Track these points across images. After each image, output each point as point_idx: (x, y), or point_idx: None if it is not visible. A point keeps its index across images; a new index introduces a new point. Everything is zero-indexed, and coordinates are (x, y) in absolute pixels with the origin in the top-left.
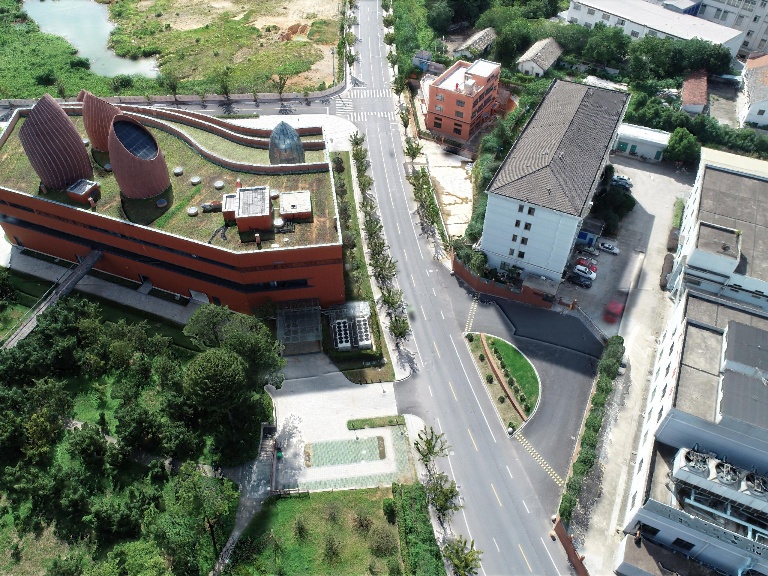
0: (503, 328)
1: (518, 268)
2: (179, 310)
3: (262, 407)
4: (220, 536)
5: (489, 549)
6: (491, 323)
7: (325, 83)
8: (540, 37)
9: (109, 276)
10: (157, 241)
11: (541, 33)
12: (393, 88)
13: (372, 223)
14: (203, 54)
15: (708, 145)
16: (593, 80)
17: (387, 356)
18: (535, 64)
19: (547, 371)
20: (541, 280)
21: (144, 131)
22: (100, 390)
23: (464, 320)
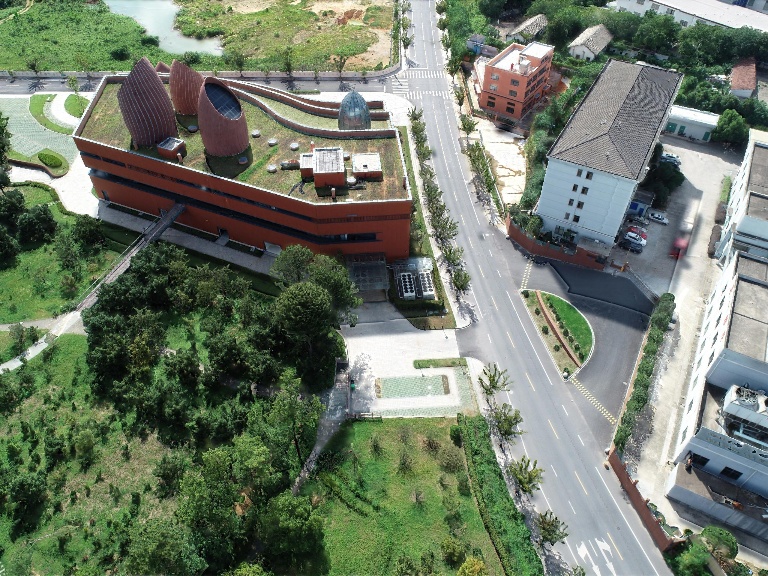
0: (557, 286)
1: (572, 232)
2: (254, 260)
3: (335, 345)
4: (304, 449)
5: (547, 474)
6: (546, 282)
7: (382, 64)
8: (590, 24)
9: (189, 229)
10: (240, 194)
11: (592, 20)
12: (447, 69)
13: (432, 189)
14: (264, 35)
15: (756, 127)
16: None
17: (448, 307)
18: (586, 48)
19: (600, 324)
20: (595, 243)
21: (230, 94)
22: (190, 323)
23: (520, 278)
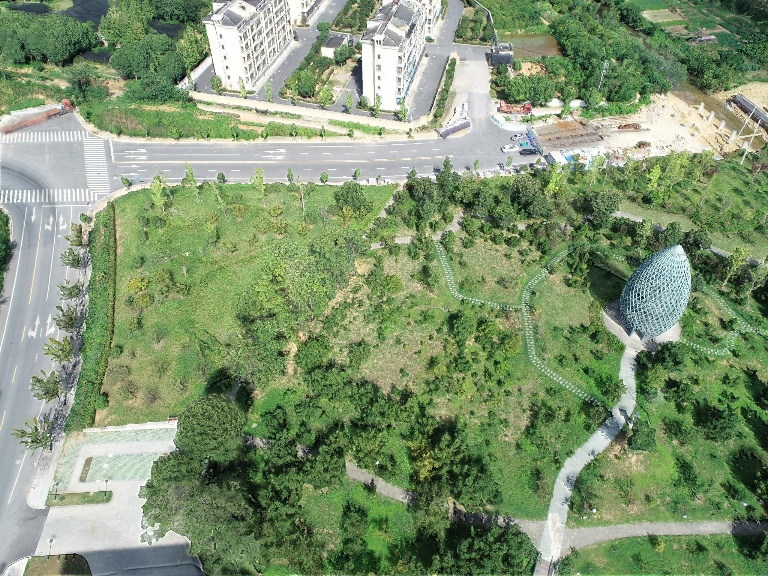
0: None
1: None
2: None
3: None
4: None
5: None
6: None
7: None
8: None
9: None
10: None
11: None
12: None
13: None
14: None
15: None
16: None
17: None
18: None
19: None
20: None
21: None
22: None
23: None
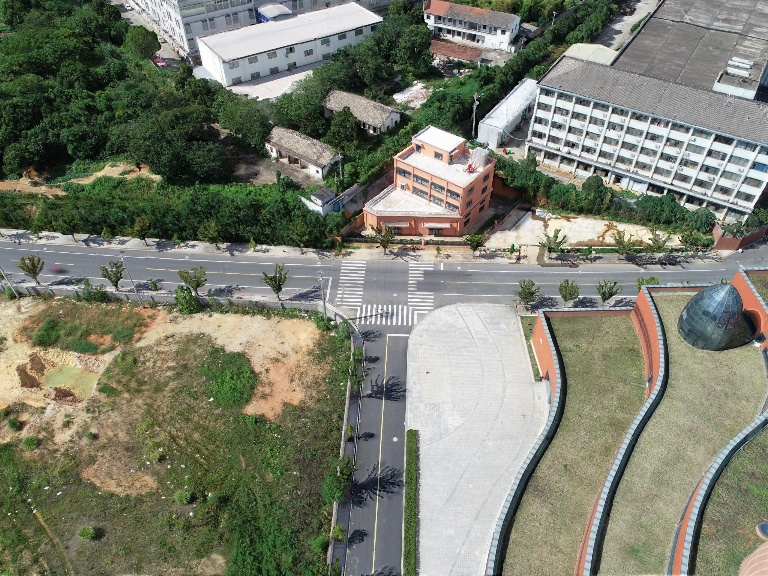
0: None
1: None
2: None
3: None
4: None
5: None
6: None
7: None
8: None
9: None
10: None
11: (319, 95)
12: None
13: None
14: (76, 569)
15: None
16: (403, 96)
17: None
18: None
19: None
20: None
21: None
22: None
23: None
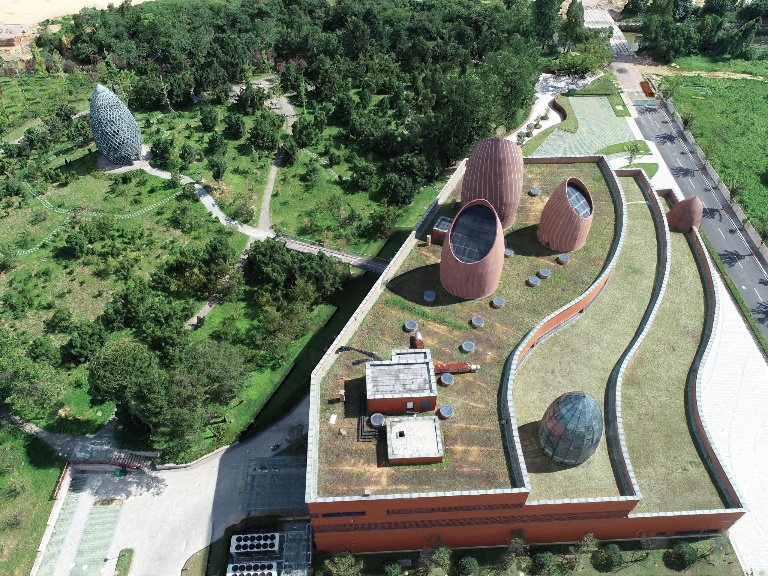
0: None
1: None
2: None
3: None
4: None
5: None
6: None
7: None
8: None
9: None
10: None
11: None
12: None
13: None
14: None
15: None
16: None
17: None
18: None
19: None
20: None
21: None
22: None
23: None
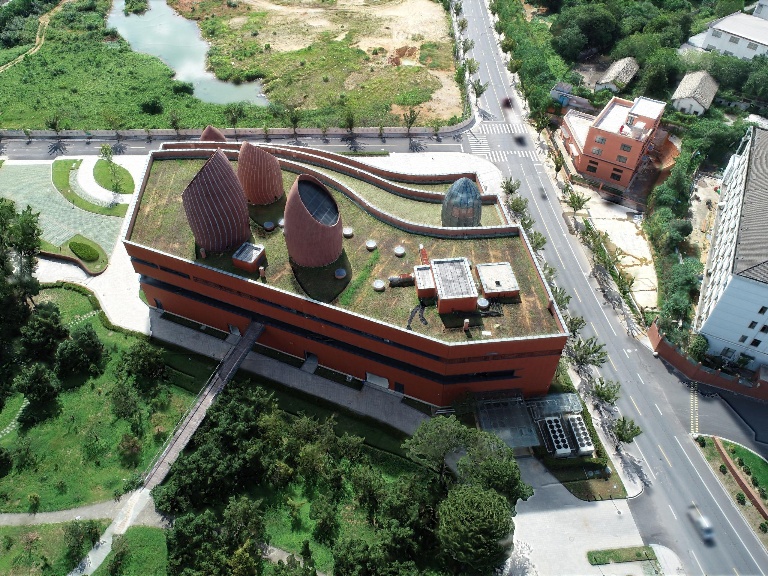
0: (739, 431)
1: (747, 357)
2: (354, 395)
3: None
4: None
5: None
6: (722, 423)
7: None
8: (687, 69)
9: (266, 349)
10: (343, 322)
11: (691, 65)
12: None
13: (557, 292)
14: (311, 79)
15: None
16: (757, 120)
17: (609, 463)
18: (695, 102)
19: None
20: None
21: (323, 191)
22: (294, 507)
23: (686, 417)
